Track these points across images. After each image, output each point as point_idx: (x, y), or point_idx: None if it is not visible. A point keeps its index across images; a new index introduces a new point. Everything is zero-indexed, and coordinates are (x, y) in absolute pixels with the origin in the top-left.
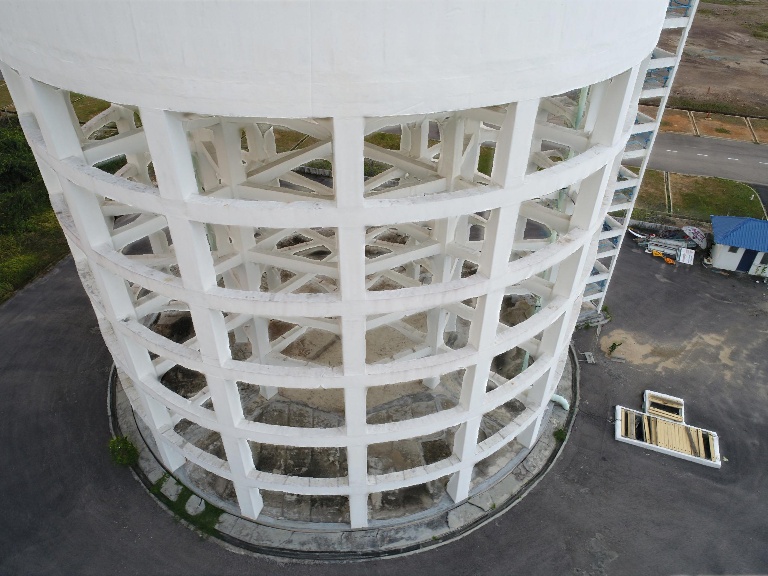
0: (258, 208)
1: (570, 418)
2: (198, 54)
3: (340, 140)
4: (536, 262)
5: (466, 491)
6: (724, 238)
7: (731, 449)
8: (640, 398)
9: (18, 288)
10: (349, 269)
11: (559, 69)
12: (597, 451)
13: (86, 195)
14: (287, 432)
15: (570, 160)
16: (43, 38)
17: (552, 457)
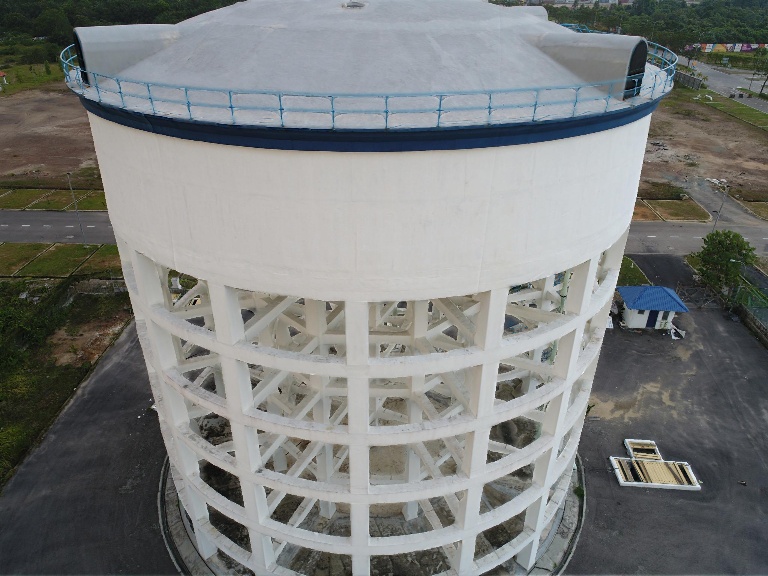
0: (428, 361)
1: (580, 476)
2: (404, 262)
3: (493, 304)
4: (588, 361)
5: (534, 557)
6: (634, 304)
7: (701, 473)
8: (623, 447)
9: (16, 463)
10: (486, 393)
11: (610, 233)
12: (611, 498)
13: (244, 369)
14: (414, 539)
15: (602, 285)
16: (258, 259)
17: (580, 512)
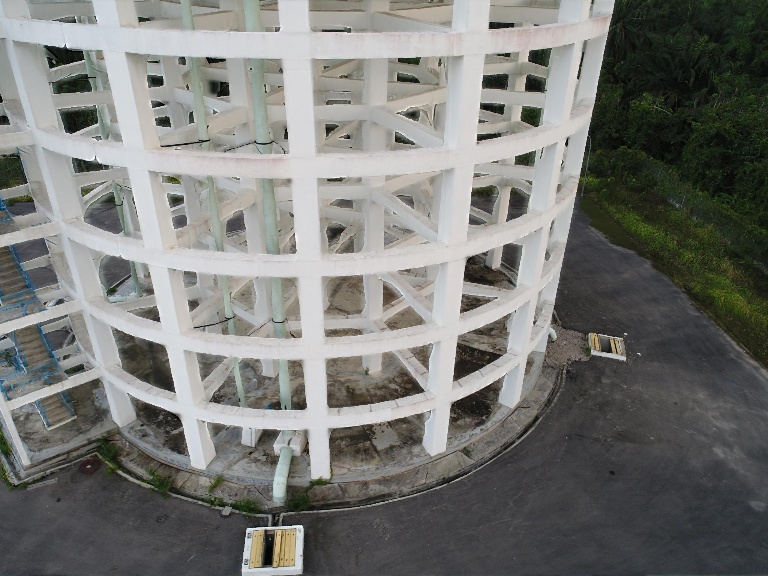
0: None
1: None
2: None
3: None
4: None
5: None
6: None
7: None
8: None
9: None
10: None
11: None
12: None
13: None
14: None
15: None
16: None
17: None
